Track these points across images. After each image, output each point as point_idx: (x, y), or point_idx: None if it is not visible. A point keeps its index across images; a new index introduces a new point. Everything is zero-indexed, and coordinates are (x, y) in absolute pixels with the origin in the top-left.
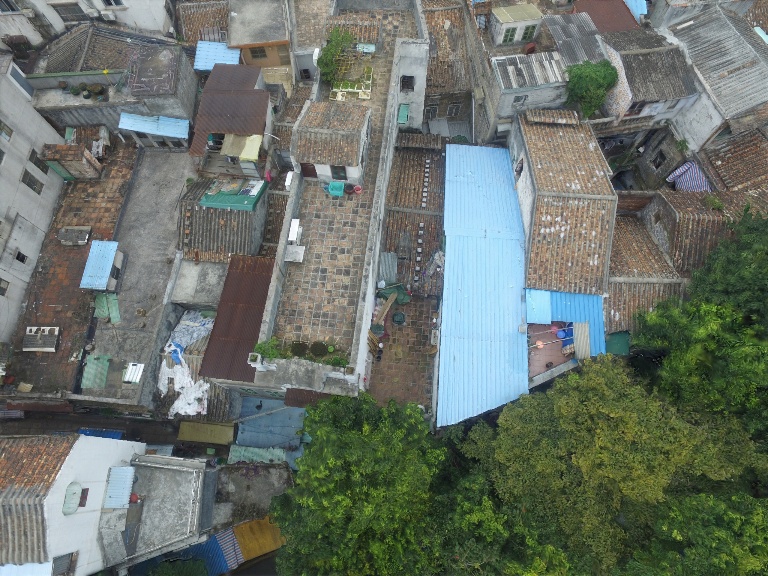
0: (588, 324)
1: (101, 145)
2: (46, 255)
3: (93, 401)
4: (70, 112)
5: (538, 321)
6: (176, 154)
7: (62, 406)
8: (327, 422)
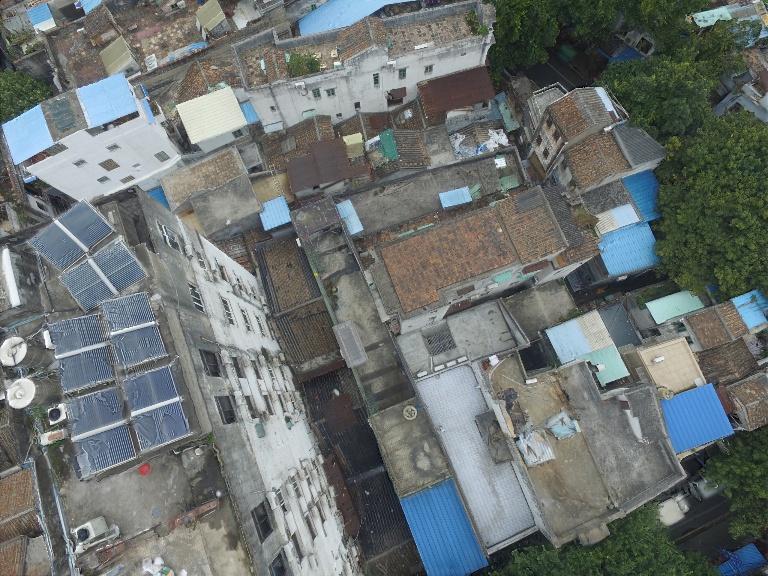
0: None
1: None
2: None
3: None
4: None
5: None
6: None
7: None
8: None
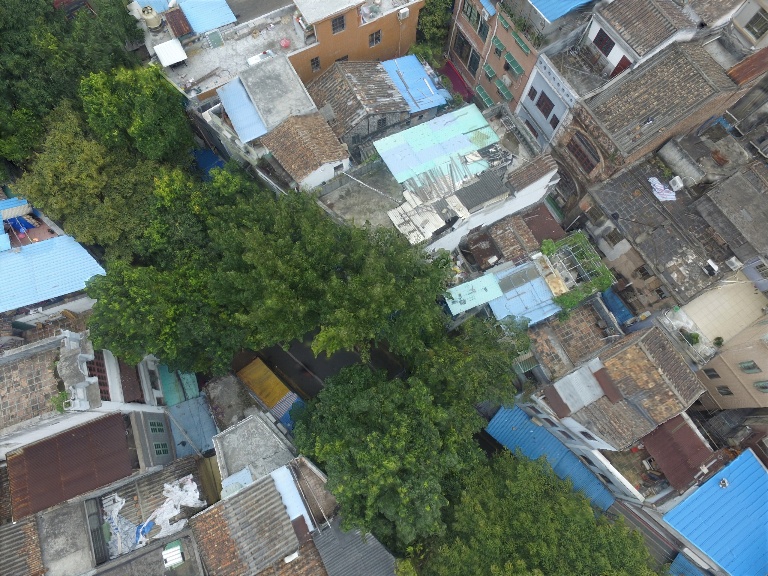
0: (1, 211)
1: None
2: None
3: (203, 571)
4: None
5: (7, 242)
6: None
7: None
8: (99, 330)
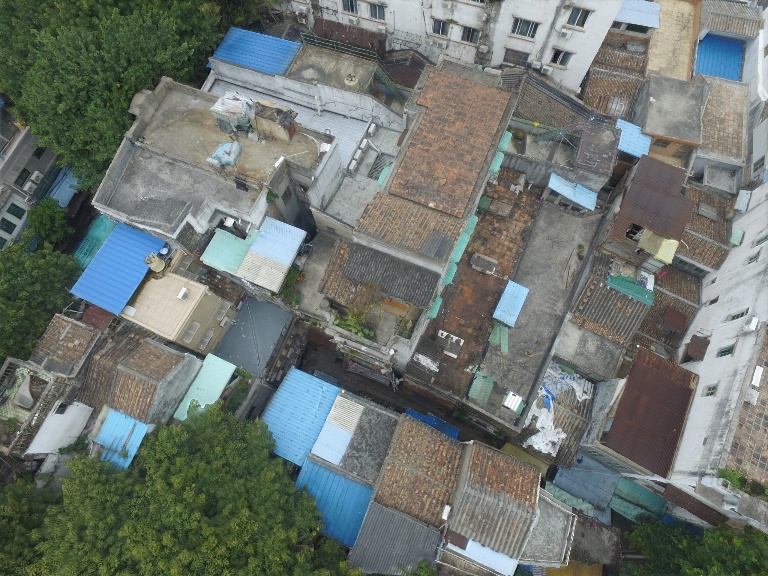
0: None
1: (518, 190)
2: (457, 272)
3: (486, 415)
4: (511, 158)
5: None
6: (569, 216)
7: (447, 402)
8: None
